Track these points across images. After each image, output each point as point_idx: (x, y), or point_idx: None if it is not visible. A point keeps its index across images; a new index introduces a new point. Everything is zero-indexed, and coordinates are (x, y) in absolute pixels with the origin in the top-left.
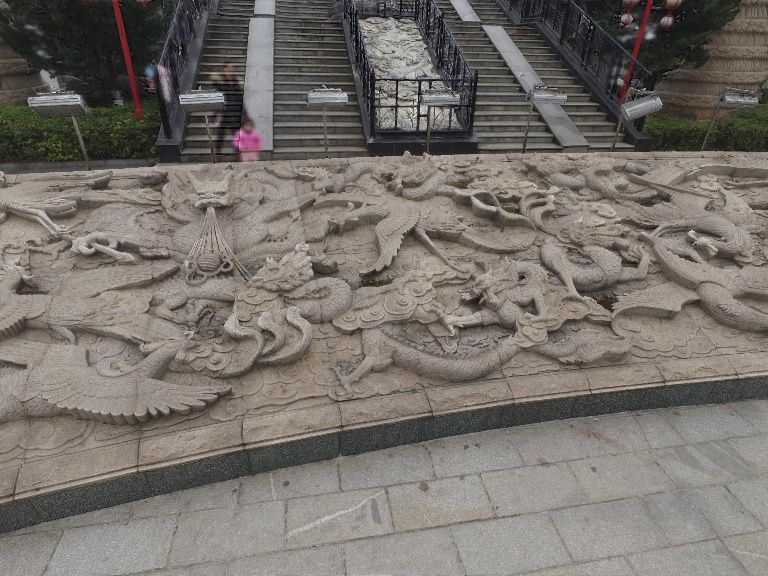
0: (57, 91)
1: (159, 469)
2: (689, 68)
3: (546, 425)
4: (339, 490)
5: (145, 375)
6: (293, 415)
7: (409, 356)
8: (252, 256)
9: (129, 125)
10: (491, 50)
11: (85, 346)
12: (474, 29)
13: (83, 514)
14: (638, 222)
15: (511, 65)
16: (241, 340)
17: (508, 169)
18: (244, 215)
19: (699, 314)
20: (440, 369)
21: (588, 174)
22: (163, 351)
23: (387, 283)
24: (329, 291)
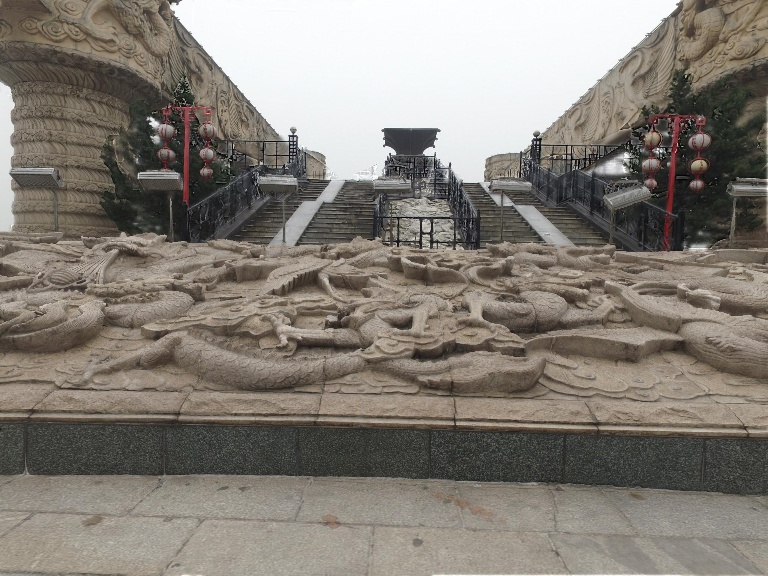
0: None
1: None
2: (743, 234)
3: (382, 481)
4: None
5: None
6: None
7: (191, 347)
8: None
9: None
10: (519, 221)
11: None
12: (505, 208)
13: None
14: None
15: (536, 228)
16: None
17: None
18: (152, 264)
19: (685, 360)
20: (223, 364)
21: (559, 251)
22: None
23: None
24: None
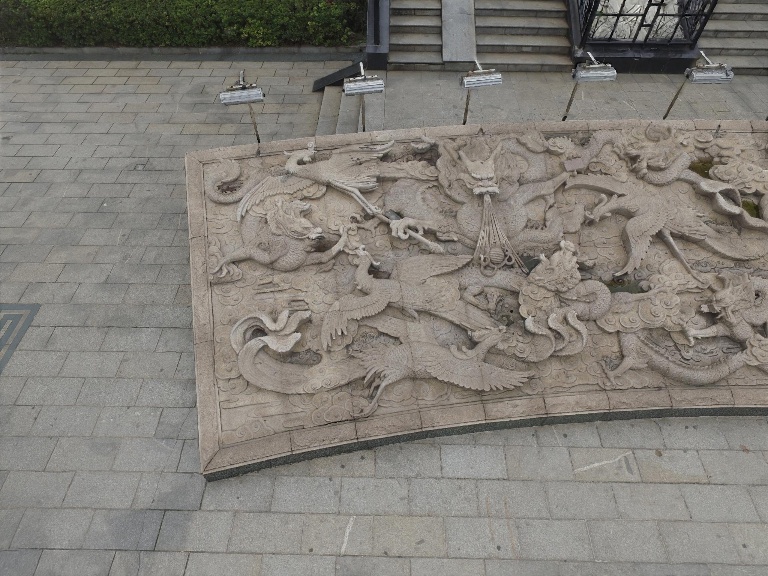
0: None
1: (496, 422)
2: None
3: (748, 419)
4: (601, 446)
5: (481, 359)
6: (578, 398)
7: (661, 364)
8: (520, 244)
9: (324, 10)
10: None
11: (425, 323)
12: None
13: (447, 436)
14: None
15: None
16: (536, 335)
17: (751, 145)
18: (508, 198)
19: None
20: (684, 377)
21: None
22: (489, 342)
23: (634, 284)
24: (597, 297)
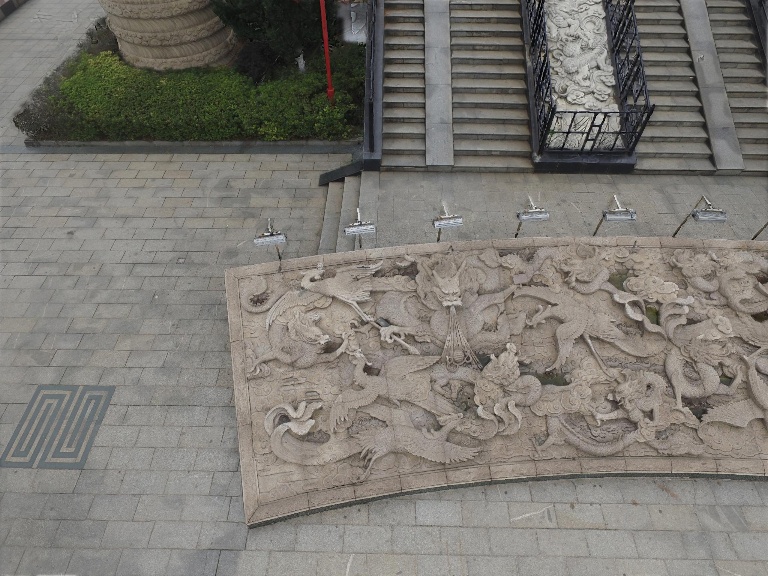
0: (361, 223)
1: None
2: None
3: (640, 479)
4: (531, 501)
5: (444, 439)
6: (514, 467)
7: (574, 442)
8: (477, 343)
9: (328, 114)
10: (675, 9)
11: (405, 409)
12: None
13: (420, 494)
14: (746, 340)
15: (692, 41)
16: (485, 419)
17: (658, 259)
18: (469, 306)
19: (759, 426)
20: (590, 451)
21: (722, 282)
22: (451, 426)
23: (561, 377)
24: None
